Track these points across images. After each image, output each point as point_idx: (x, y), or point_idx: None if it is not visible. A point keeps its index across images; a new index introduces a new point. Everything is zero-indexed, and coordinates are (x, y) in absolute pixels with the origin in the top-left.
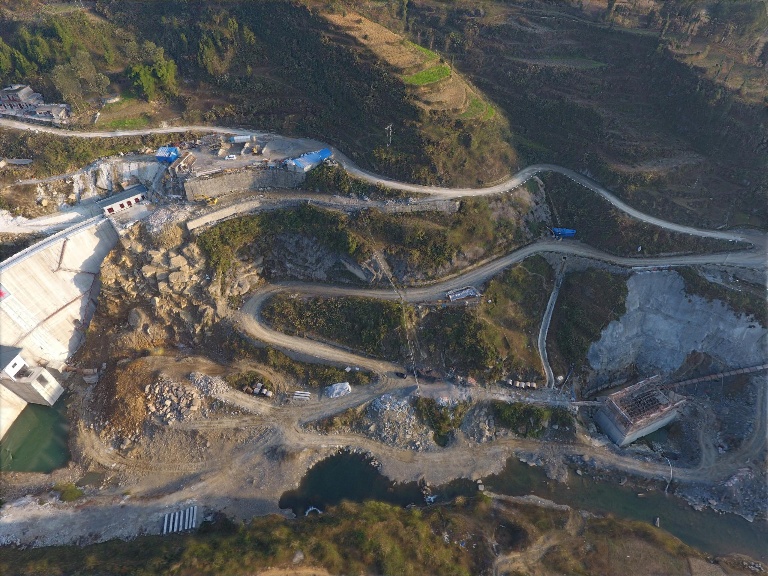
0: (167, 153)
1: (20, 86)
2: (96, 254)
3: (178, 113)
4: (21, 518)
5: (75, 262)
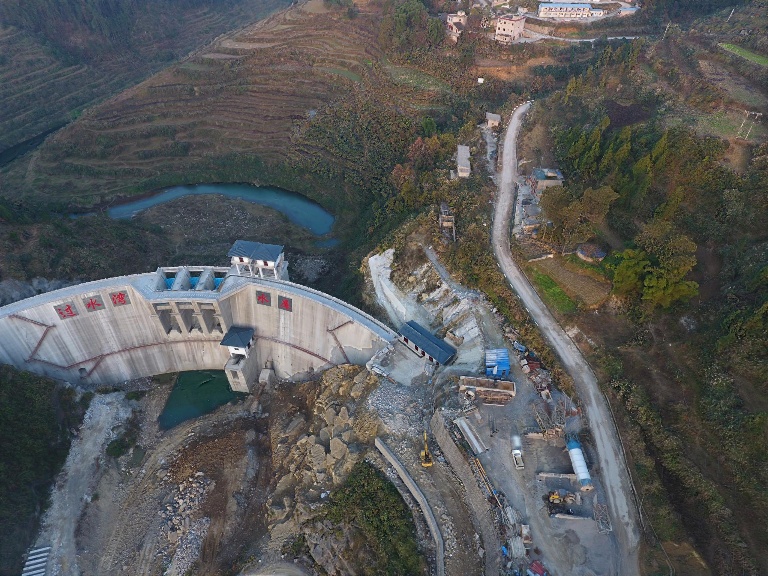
0: (494, 362)
1: (557, 175)
2: (362, 352)
3: (605, 339)
4: (103, 420)
5: (345, 340)
